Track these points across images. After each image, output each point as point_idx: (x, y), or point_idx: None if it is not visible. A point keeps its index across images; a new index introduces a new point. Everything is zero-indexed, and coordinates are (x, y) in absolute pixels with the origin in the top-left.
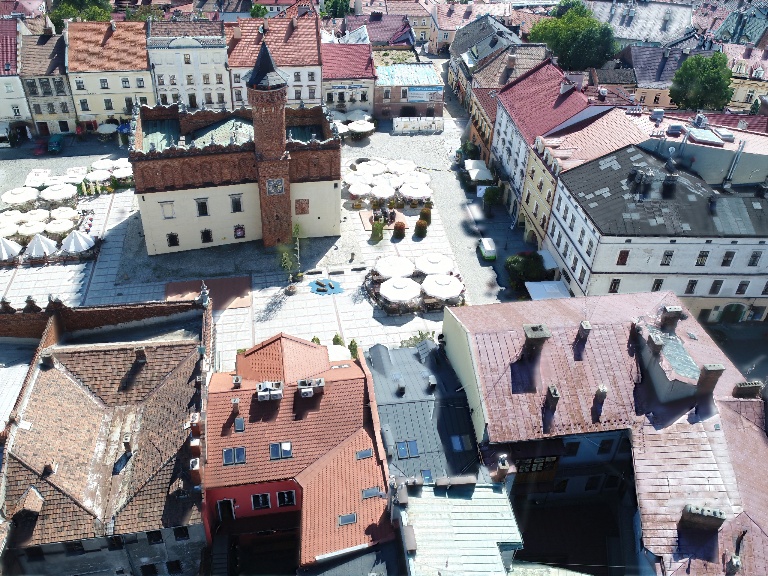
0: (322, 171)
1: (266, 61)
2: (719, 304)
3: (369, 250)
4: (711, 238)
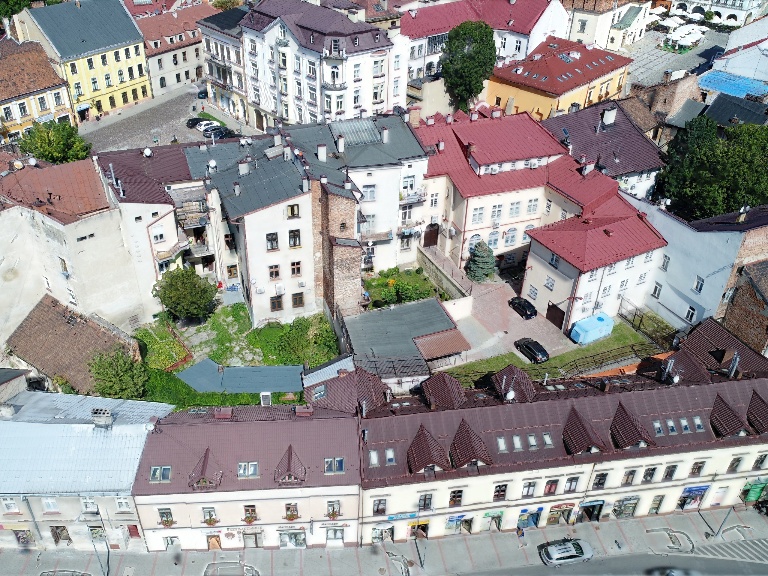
0: None
1: None
2: None
3: None
4: None
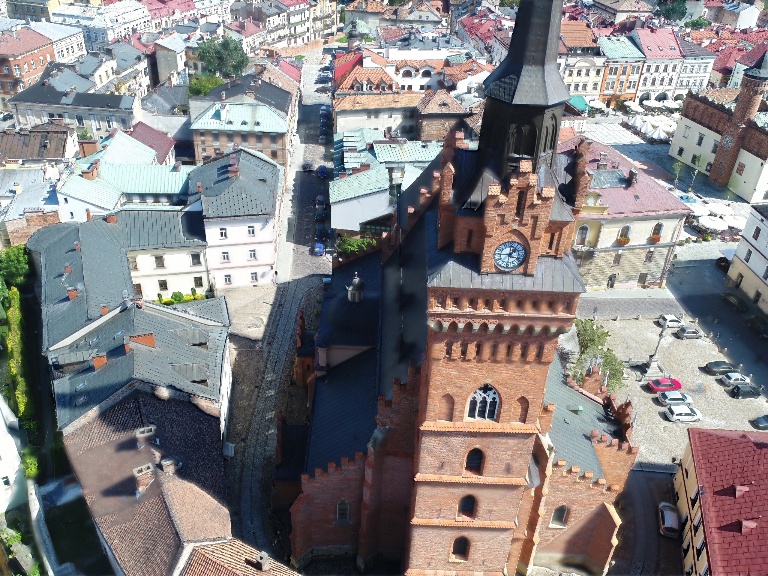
0: (761, 150)
1: (760, 61)
2: None
3: (745, 213)
4: None
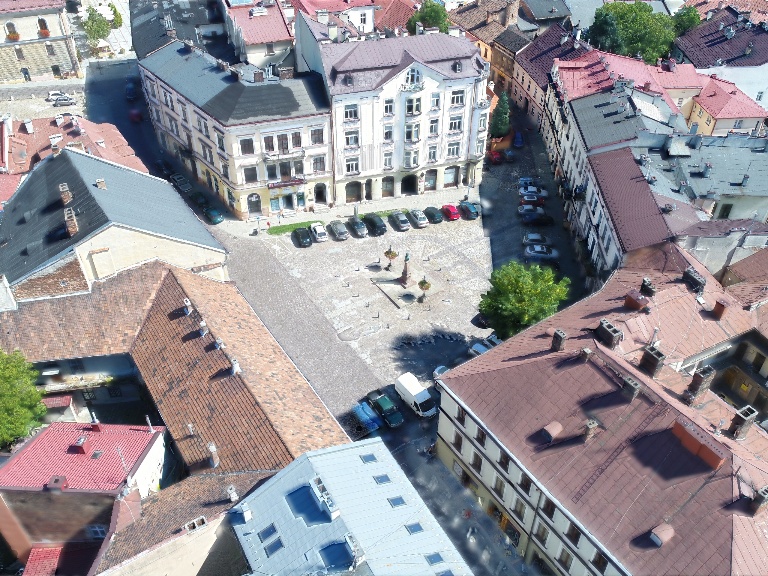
0: None
1: None
2: None
3: None
4: None
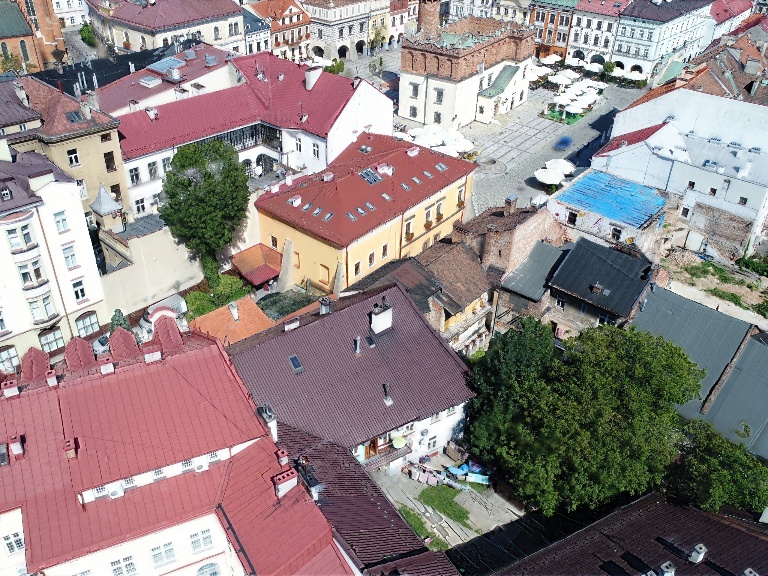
0: None
1: None
2: None
3: None
4: None
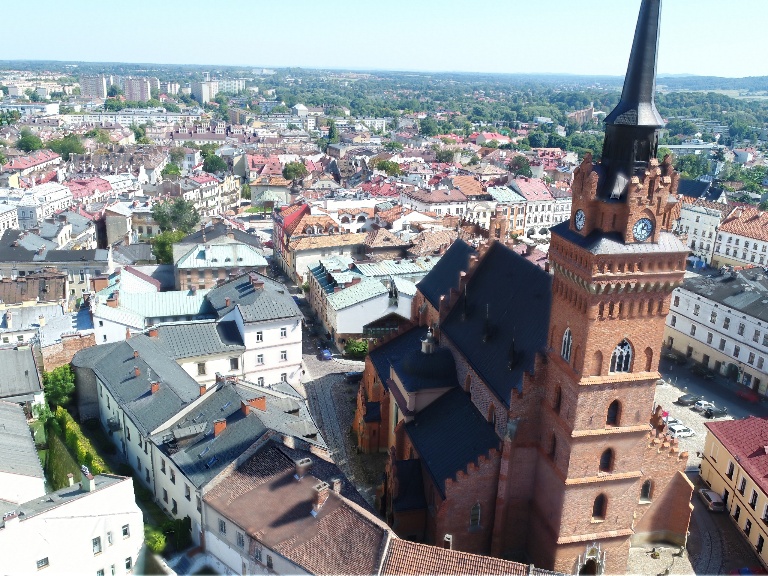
0: None
1: None
2: (725, 360)
3: None
4: (715, 302)
